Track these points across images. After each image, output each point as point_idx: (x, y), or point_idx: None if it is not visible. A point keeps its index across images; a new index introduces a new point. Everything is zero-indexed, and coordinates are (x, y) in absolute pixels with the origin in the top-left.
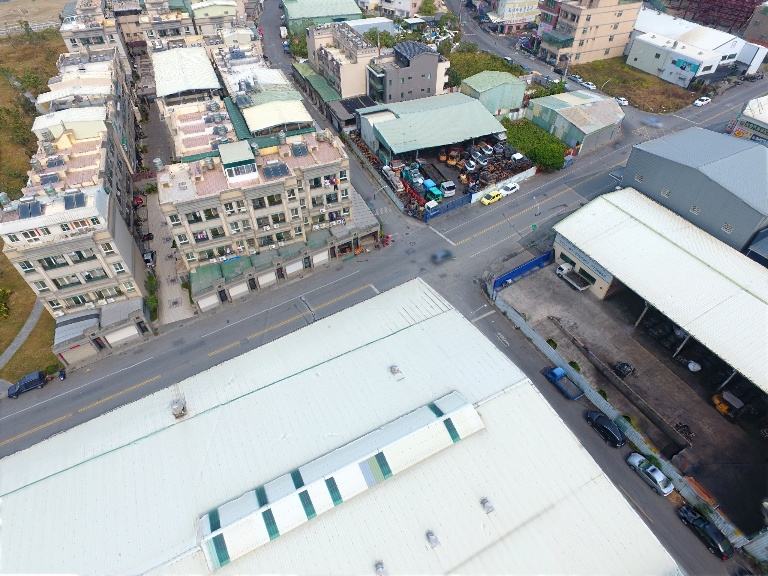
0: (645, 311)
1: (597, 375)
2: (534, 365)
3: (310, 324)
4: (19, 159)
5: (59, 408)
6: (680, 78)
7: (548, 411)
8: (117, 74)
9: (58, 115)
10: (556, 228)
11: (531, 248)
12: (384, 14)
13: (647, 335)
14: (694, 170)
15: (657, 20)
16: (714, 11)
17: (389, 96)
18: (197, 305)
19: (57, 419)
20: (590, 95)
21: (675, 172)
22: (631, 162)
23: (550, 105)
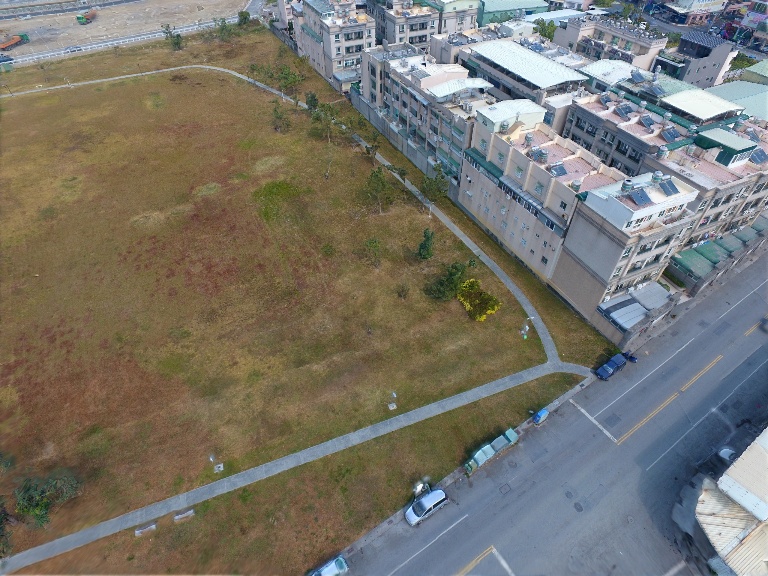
0: None
1: None
2: None
3: None
4: (338, 155)
5: (659, 388)
6: None
7: None
8: None
9: (501, 107)
10: None
11: None
12: (550, 6)
13: None
14: None
15: None
16: None
17: None
18: (700, 288)
19: (670, 398)
20: None
21: None
22: None
23: None
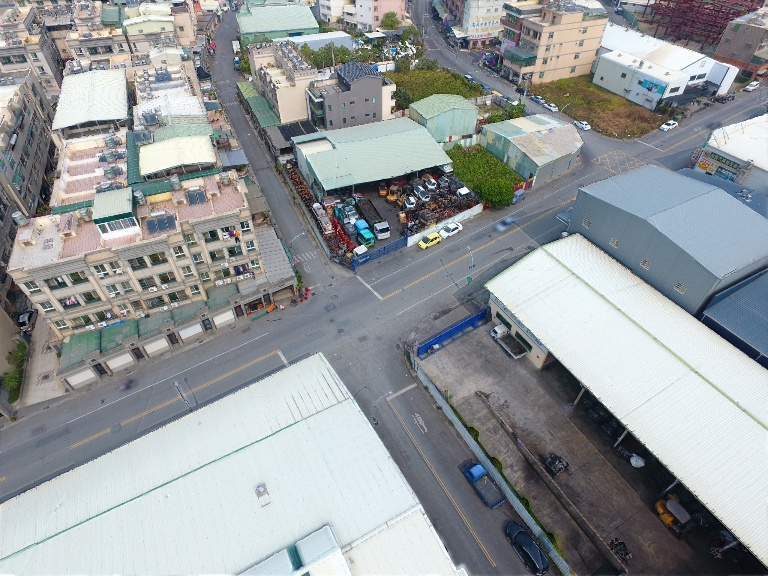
0: (583, 390)
1: (526, 469)
2: (452, 458)
3: (178, 419)
4: None
5: None
6: (647, 100)
7: (439, 553)
8: (27, 99)
9: None
10: (488, 286)
11: (467, 302)
12: (346, 27)
13: (587, 417)
14: (642, 221)
15: (624, 37)
16: (686, 26)
17: (330, 122)
18: (66, 383)
19: None
20: (548, 120)
21: (623, 221)
22: (578, 206)
23: (503, 132)
